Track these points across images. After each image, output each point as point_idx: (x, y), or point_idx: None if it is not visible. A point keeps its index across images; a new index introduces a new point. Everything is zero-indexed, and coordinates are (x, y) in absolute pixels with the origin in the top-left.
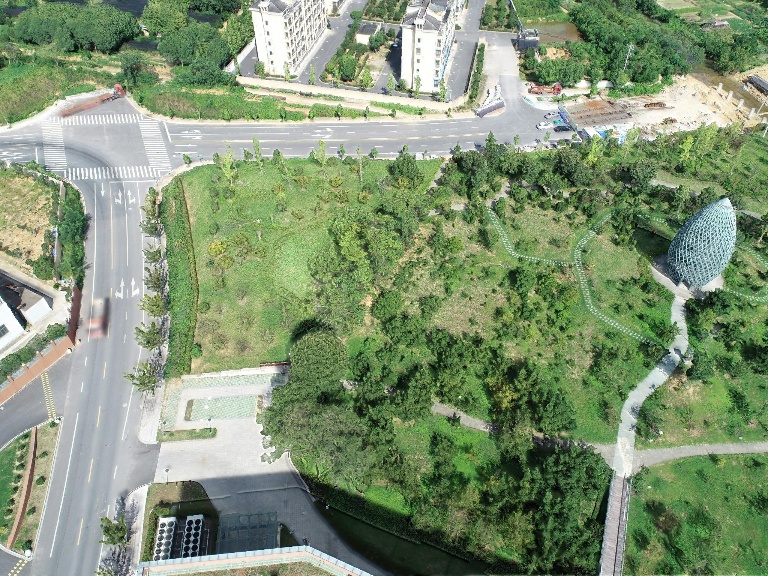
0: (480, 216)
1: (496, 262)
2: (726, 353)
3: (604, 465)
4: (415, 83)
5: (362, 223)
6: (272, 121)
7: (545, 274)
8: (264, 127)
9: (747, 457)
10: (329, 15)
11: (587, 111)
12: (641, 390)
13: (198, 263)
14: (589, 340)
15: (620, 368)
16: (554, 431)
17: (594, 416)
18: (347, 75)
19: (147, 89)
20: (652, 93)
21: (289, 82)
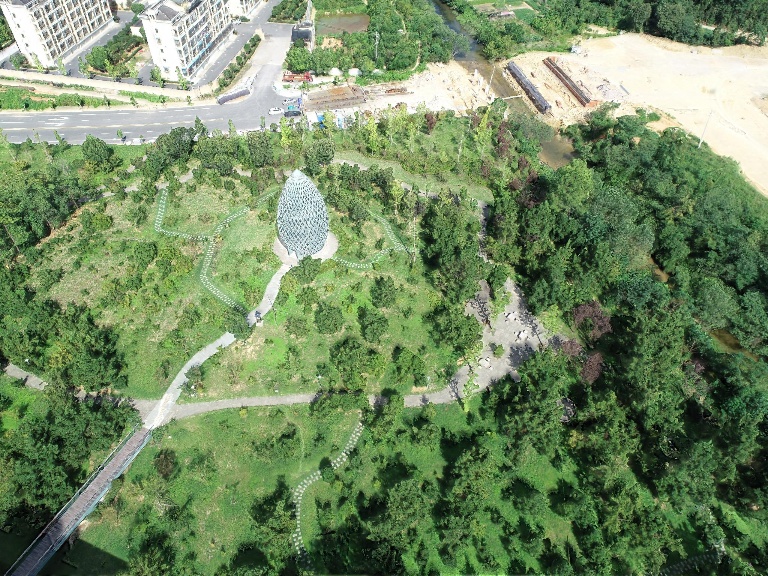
0: (149, 195)
1: (133, 237)
2: (302, 315)
3: (133, 418)
4: (166, 72)
5: (9, 202)
6: (14, 111)
7: (174, 247)
8: (3, 116)
9: (274, 408)
10: (124, 9)
11: (326, 97)
12: (208, 350)
13: None
14: (185, 307)
15: (199, 331)
16: (94, 388)
17: (151, 375)
18: (99, 66)
19: None
20: (401, 80)
21: (45, 73)
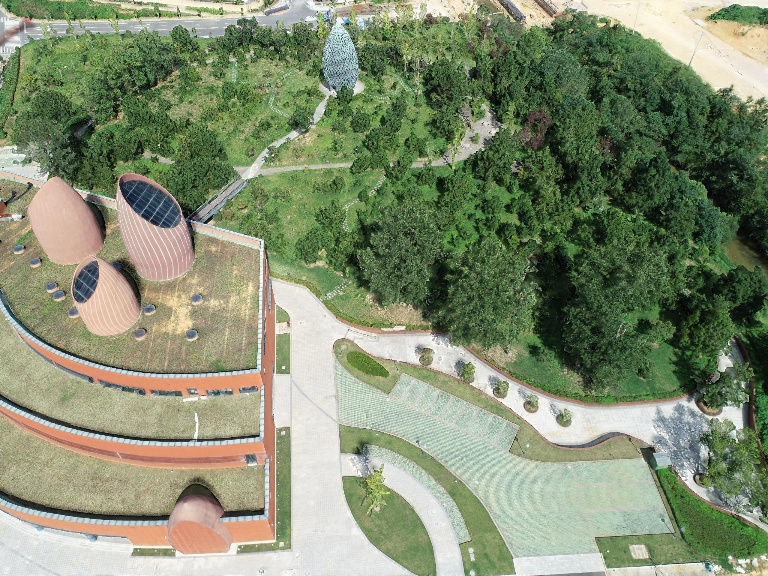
0: None
1: (218, 84)
2: None
3: (235, 173)
4: None
5: None
6: (107, 20)
7: None
8: (99, 24)
9: (326, 169)
10: None
11: None
12: (279, 142)
13: (17, 91)
14: None
15: None
16: None
17: (242, 154)
18: None
19: (16, 1)
20: None
21: None
